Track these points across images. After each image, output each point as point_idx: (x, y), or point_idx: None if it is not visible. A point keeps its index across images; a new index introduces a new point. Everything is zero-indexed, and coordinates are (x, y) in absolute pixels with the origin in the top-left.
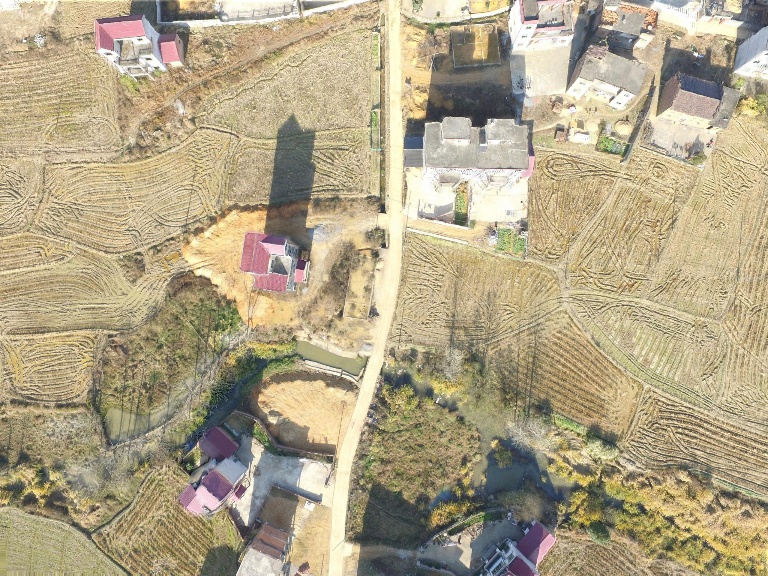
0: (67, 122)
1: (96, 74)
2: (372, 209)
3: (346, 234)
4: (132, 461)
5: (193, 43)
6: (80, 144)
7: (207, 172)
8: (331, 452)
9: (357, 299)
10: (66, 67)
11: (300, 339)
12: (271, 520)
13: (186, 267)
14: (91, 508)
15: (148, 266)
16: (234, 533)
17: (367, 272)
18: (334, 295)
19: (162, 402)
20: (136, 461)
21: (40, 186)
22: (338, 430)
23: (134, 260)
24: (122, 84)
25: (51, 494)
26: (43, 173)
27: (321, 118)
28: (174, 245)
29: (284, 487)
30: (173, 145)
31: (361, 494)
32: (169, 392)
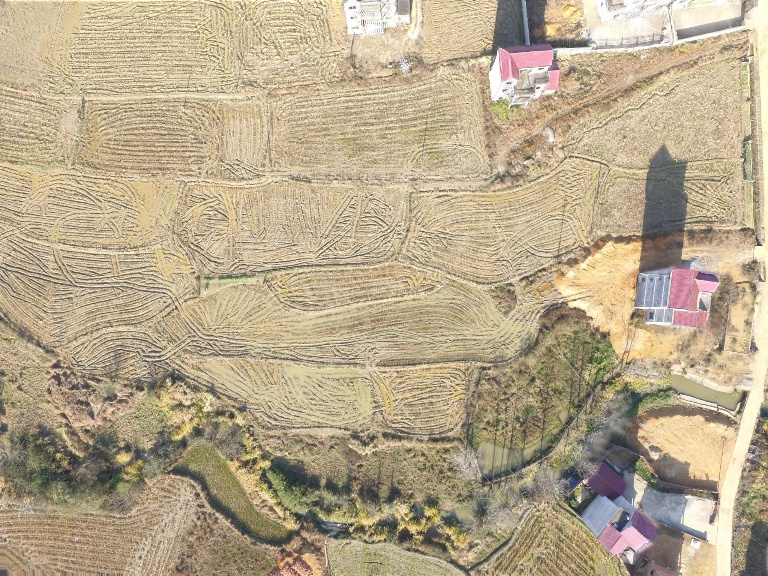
0: (434, 149)
1: (461, 101)
2: (749, 241)
3: (723, 267)
4: (505, 496)
5: (560, 71)
6: (447, 172)
7: (577, 202)
8: (713, 489)
9: (738, 333)
10: (429, 93)
11: (674, 373)
12: (657, 558)
13: (559, 299)
14: (469, 545)
15: (520, 297)
16: (617, 571)
17: (747, 306)
18: (715, 329)
19: (536, 436)
20: (510, 496)
21: (407, 214)
22: (719, 466)
23: (506, 291)
24: (492, 112)
25: (428, 530)
26: (409, 201)
27: (692, 148)
28: (546, 276)
29: (668, 524)
30: (542, 174)
31: (744, 532)
32: (543, 426)
